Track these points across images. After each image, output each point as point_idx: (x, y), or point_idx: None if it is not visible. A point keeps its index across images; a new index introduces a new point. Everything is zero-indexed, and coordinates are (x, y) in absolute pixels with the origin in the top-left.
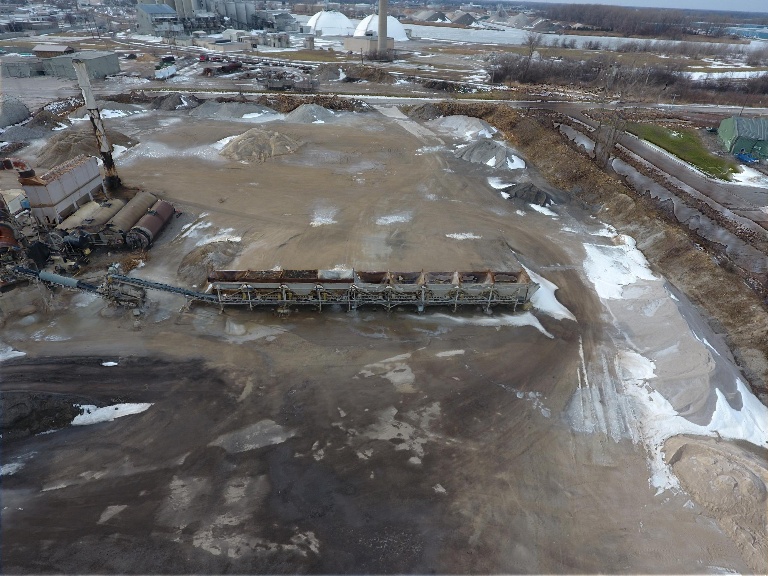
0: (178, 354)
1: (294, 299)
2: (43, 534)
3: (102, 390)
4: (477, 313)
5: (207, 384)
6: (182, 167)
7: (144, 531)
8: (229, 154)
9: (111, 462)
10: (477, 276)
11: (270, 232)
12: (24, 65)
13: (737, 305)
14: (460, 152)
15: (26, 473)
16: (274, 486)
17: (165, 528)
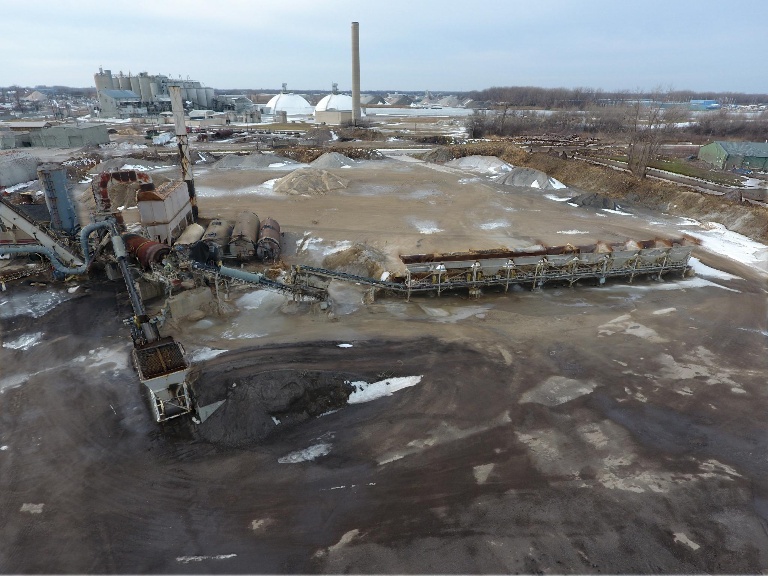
0: (402, 335)
1: (482, 280)
2: (426, 502)
3: (361, 367)
4: (651, 282)
5: (461, 354)
6: (247, 201)
7: (540, 483)
8: (285, 190)
9: (431, 429)
10: (646, 245)
11: (391, 240)
12: (10, 137)
13: None
14: (500, 179)
15: (342, 451)
16: (628, 427)
17: (559, 477)
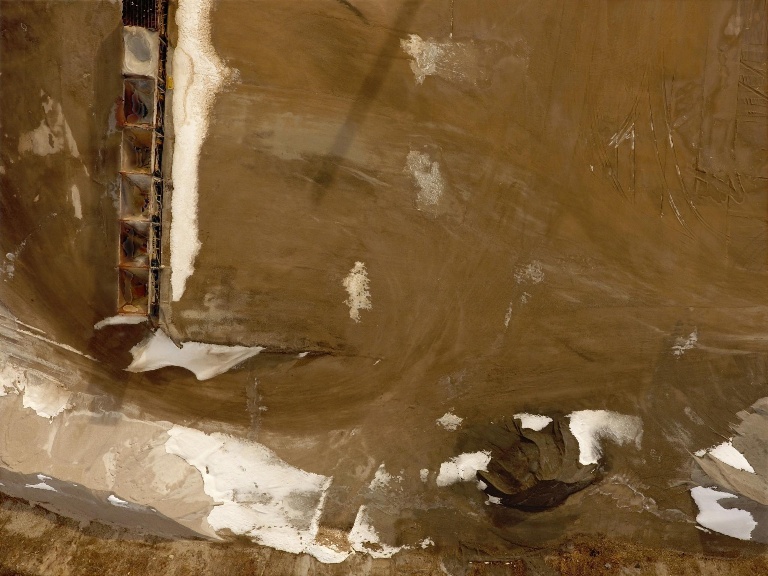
0: None
1: None
2: None
3: None
4: None
5: None
6: None
7: None
8: None
9: None
10: None
11: None
12: None
13: (99, 570)
14: None
15: None
16: None
17: None
